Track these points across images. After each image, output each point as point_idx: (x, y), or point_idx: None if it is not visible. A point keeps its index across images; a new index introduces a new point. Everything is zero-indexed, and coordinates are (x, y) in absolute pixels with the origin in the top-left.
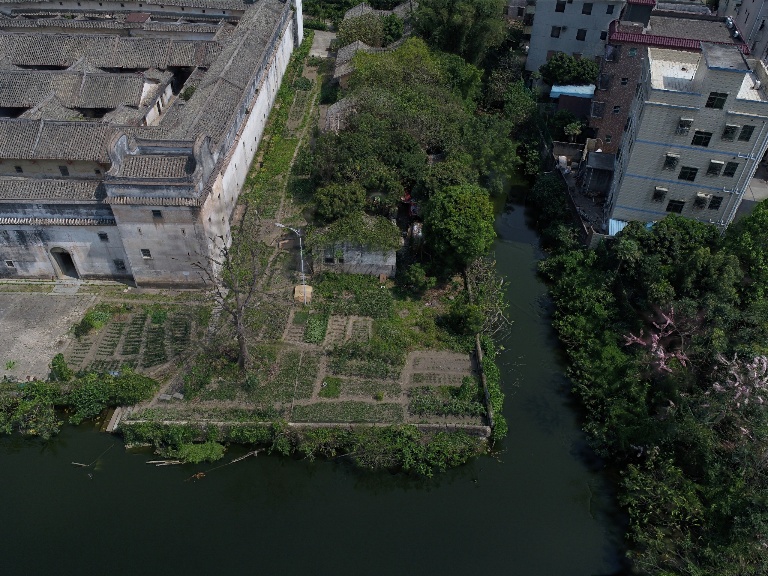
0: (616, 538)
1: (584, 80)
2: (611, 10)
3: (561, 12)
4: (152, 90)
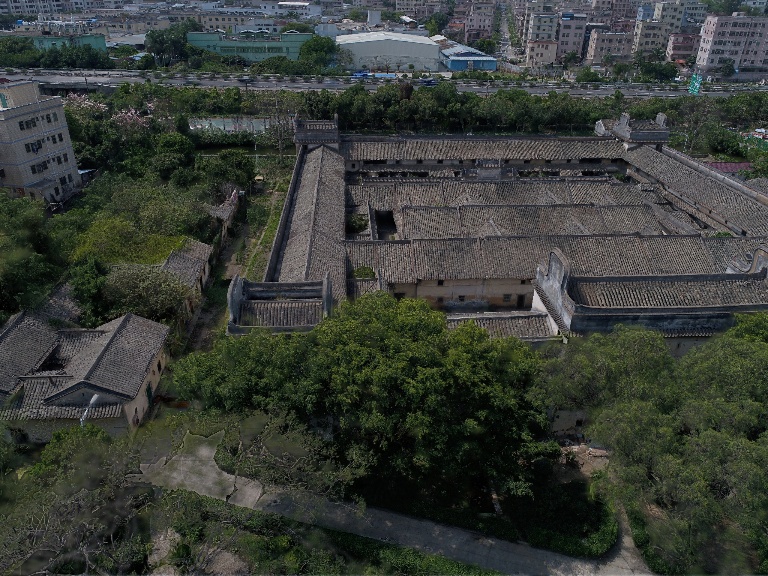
0: None
1: None
2: None
3: None
4: None
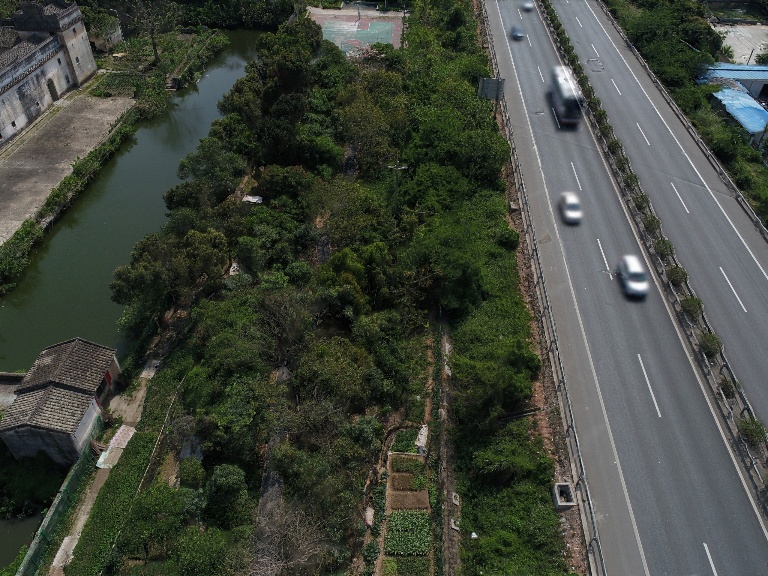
0: None
1: None
2: None
3: None
4: None
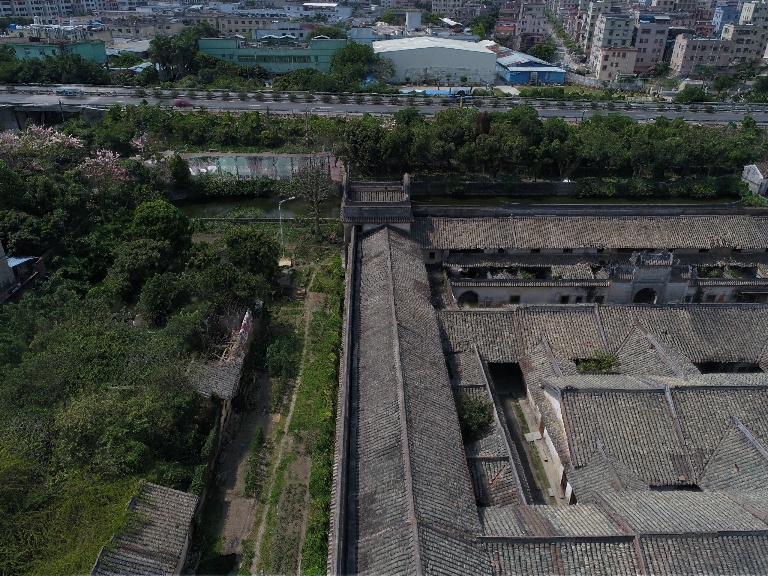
0: None
1: None
2: None
3: None
4: (565, 437)
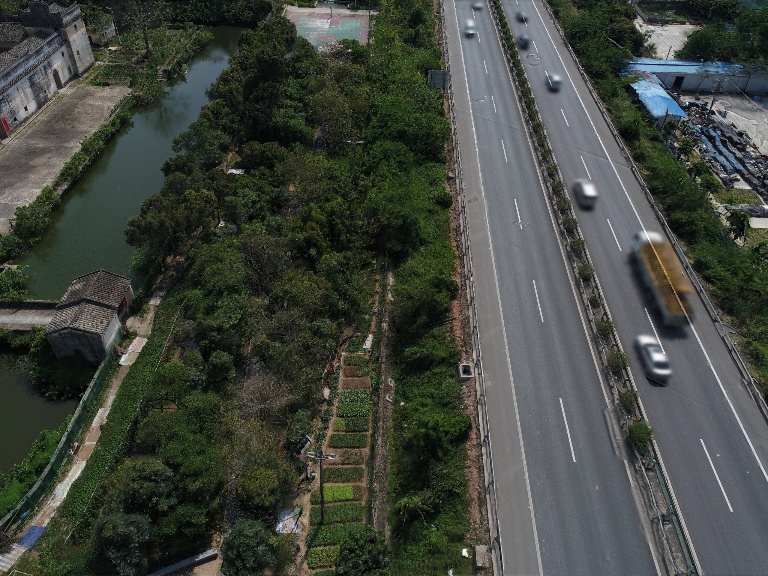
0: None
1: None
2: None
3: None
4: None
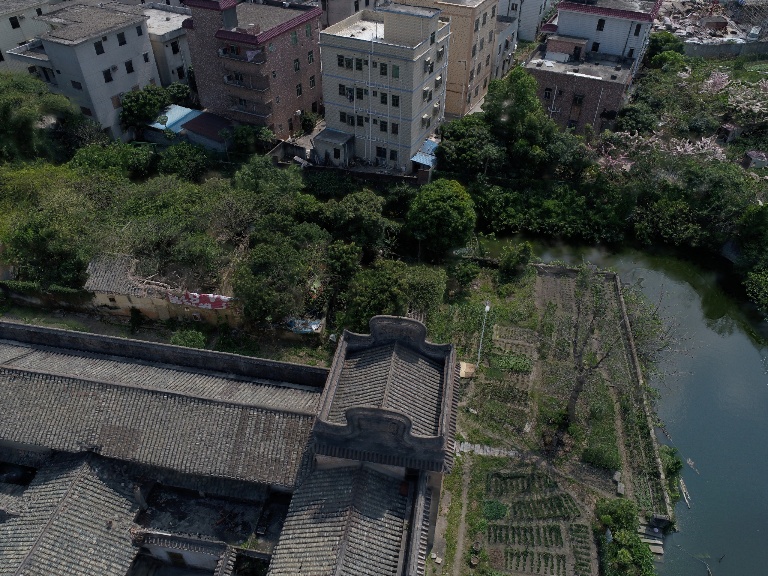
0: (671, 253)
1: (166, 105)
2: (139, 31)
3: (102, 53)
4: None
